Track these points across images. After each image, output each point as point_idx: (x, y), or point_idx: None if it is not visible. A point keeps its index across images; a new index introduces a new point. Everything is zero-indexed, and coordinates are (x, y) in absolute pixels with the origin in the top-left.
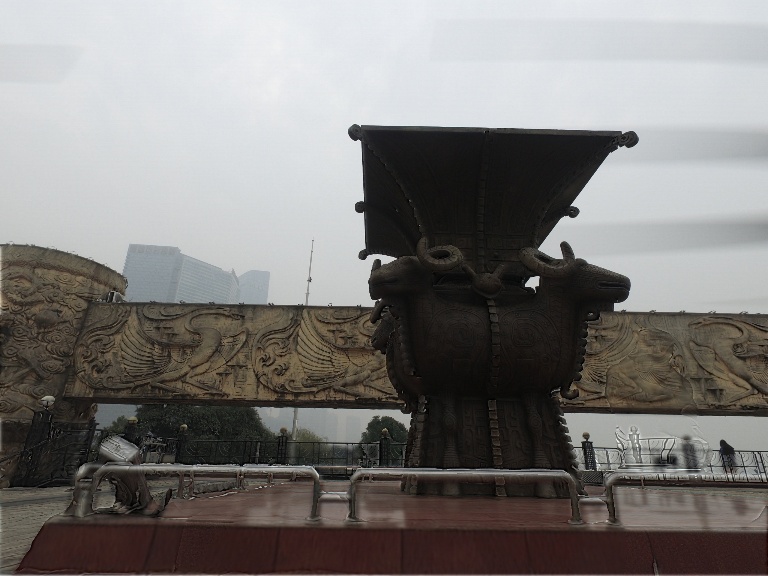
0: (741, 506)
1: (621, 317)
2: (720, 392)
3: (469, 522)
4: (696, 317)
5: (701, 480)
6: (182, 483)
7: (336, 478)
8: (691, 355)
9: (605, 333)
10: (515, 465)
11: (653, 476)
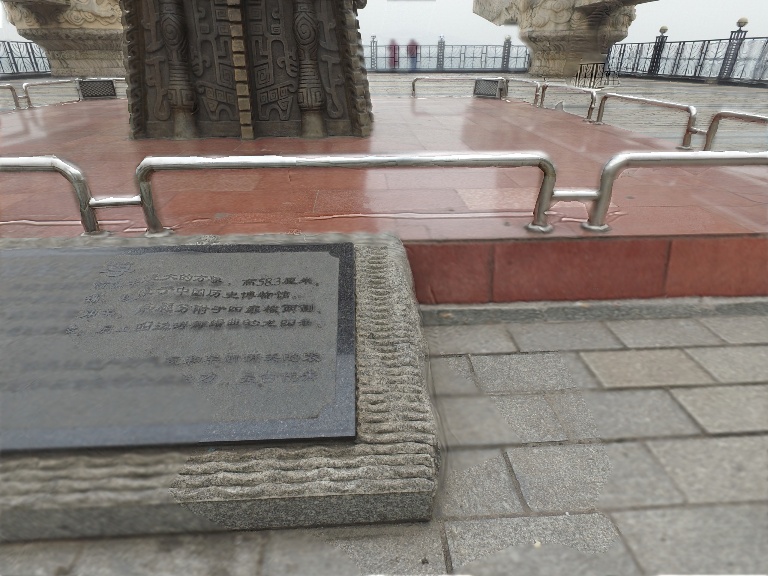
0: None
1: None
2: None
3: (633, 134)
4: None
5: None
6: None
7: None
8: None
9: None
10: None
11: None
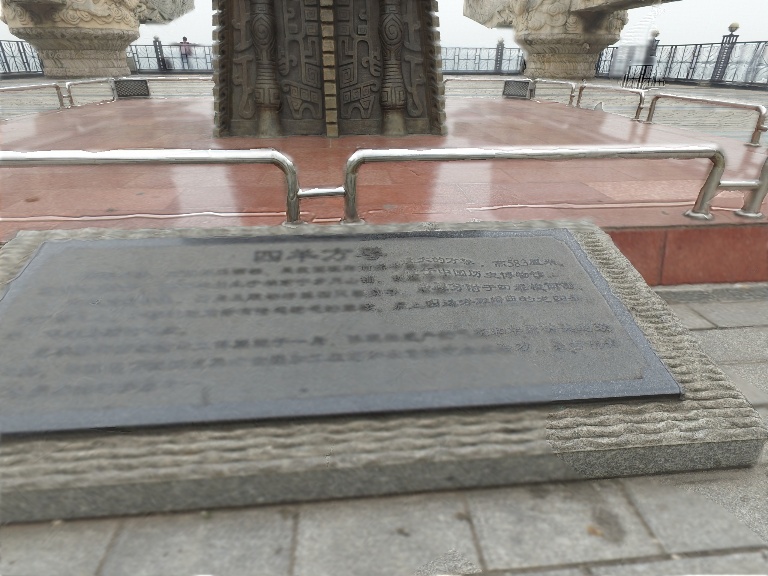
0: None
1: None
2: None
3: None
4: None
5: None
6: (760, 186)
7: None
8: None
9: None
10: None
11: None
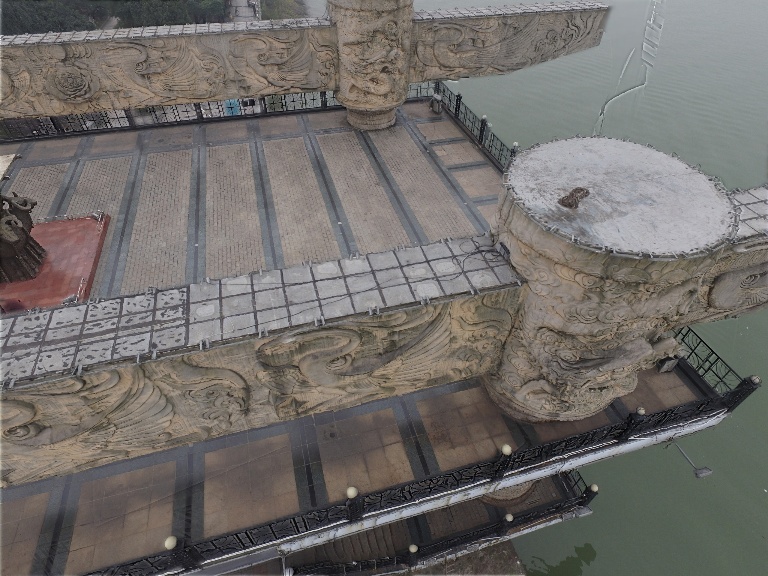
0: (56, 287)
1: (179, 39)
2: (248, 88)
3: None
4: (235, 34)
5: (266, 113)
6: None
7: (28, 140)
8: (230, 65)
9: (169, 53)
10: (12, 274)
11: (238, 113)
